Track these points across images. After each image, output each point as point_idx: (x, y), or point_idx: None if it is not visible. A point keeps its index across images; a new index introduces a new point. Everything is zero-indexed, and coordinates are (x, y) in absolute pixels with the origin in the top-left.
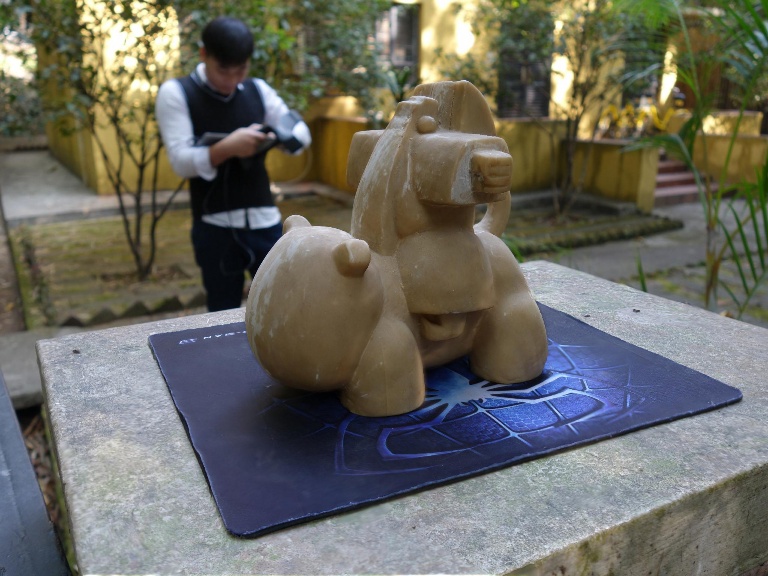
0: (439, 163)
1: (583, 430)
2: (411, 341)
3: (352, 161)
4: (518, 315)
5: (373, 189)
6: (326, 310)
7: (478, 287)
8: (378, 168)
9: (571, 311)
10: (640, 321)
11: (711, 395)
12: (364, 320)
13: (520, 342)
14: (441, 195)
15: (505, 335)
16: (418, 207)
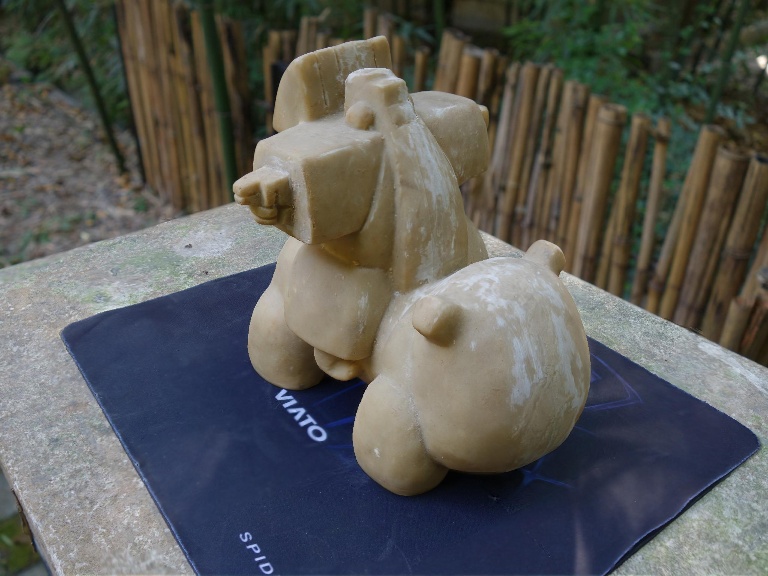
0: (474, 135)
1: None
2: None
3: (333, 200)
4: None
5: (455, 200)
6: None
7: None
8: (446, 173)
9: (186, 281)
10: (222, 247)
11: None
12: None
13: None
14: (482, 166)
15: None
16: None
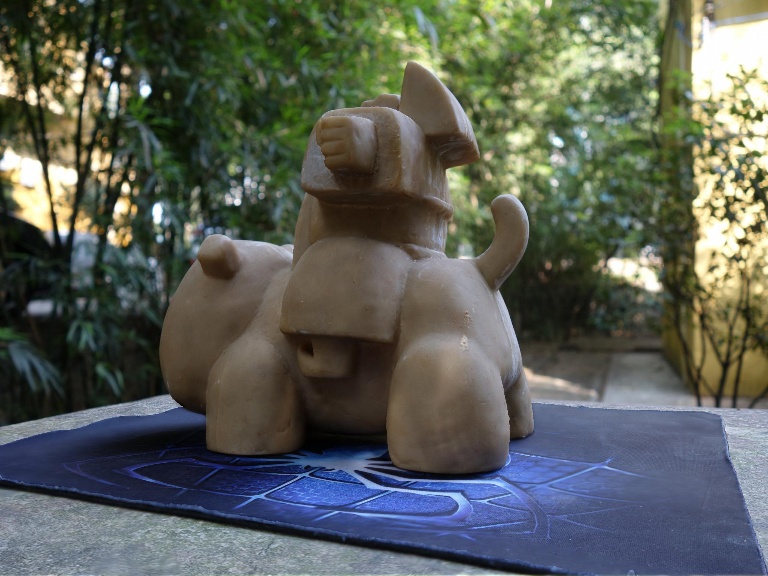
0: None
1: (331, 520)
2: (263, 365)
3: None
4: (419, 361)
5: None
6: (179, 308)
7: (338, 302)
8: None
9: (764, 454)
10: None
11: (676, 571)
12: (216, 328)
13: (413, 402)
14: None
15: (397, 387)
16: (318, 209)
